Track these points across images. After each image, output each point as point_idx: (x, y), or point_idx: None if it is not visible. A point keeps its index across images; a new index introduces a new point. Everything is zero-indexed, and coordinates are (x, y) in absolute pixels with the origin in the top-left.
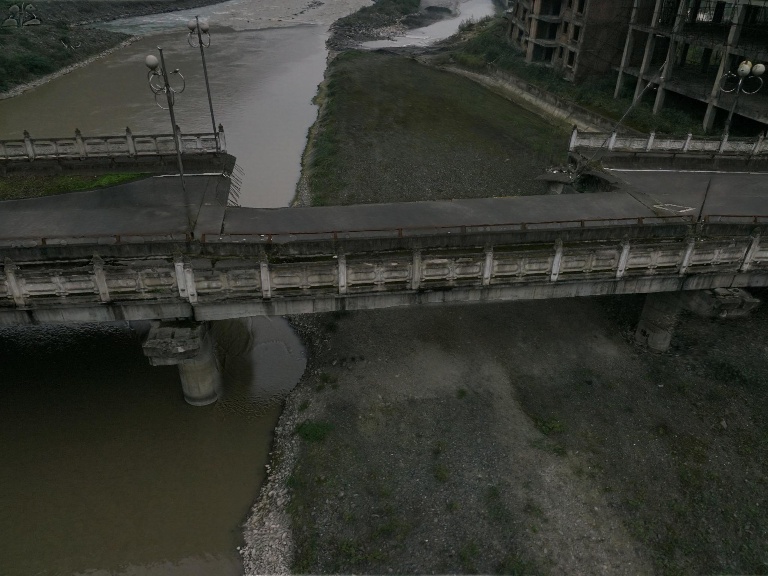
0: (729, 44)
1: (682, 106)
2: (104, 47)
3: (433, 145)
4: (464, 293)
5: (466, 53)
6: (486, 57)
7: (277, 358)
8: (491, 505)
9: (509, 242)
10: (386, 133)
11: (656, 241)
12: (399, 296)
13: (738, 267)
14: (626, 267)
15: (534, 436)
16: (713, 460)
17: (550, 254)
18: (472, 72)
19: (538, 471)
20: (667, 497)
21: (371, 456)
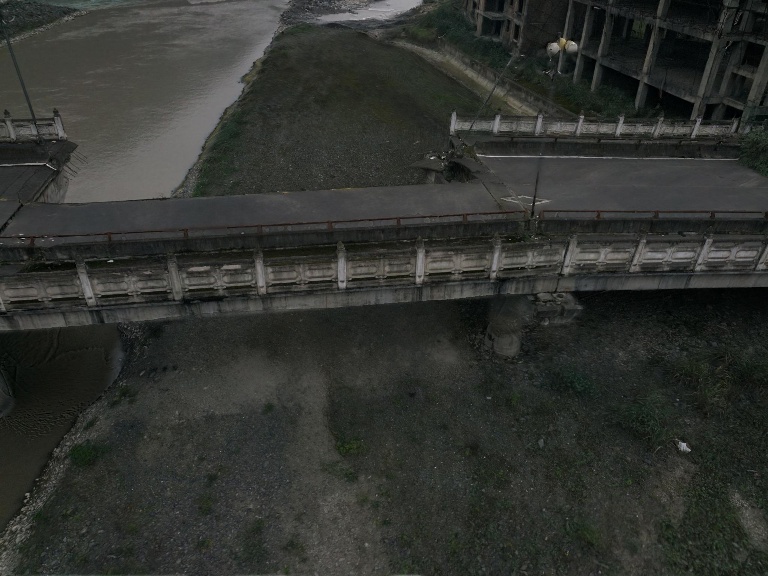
0: (658, 17)
1: (618, 83)
2: (41, 21)
3: (345, 126)
4: (242, 303)
5: (419, 27)
6: (437, 31)
7: (85, 367)
8: (249, 542)
9: (315, 242)
10: (300, 113)
11: (483, 240)
12: (165, 307)
13: (558, 270)
14: (426, 272)
15: (330, 458)
16: (515, 486)
17: (332, 259)
18: (421, 47)
19: (319, 500)
20: (448, 531)
21: (138, 484)
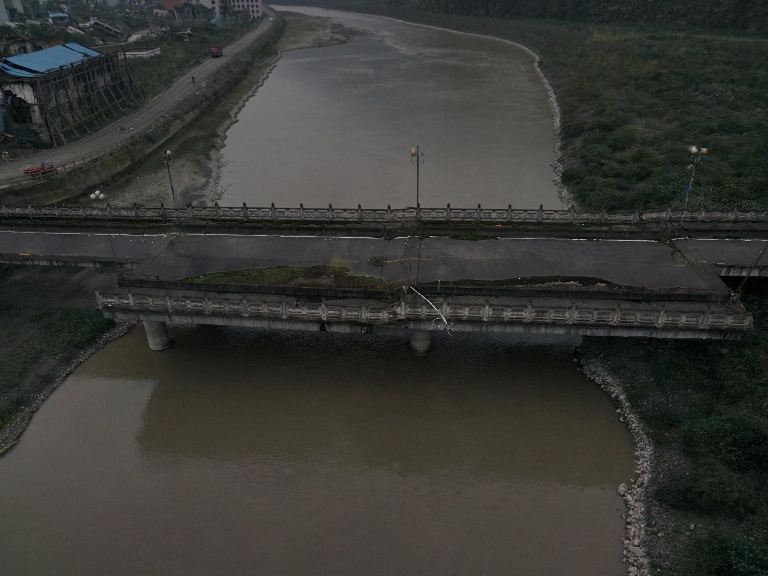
0: None
1: None
2: None
3: None
4: None
5: None
6: None
7: None
8: None
9: None
10: None
11: None
12: None
13: None
14: None
15: None
16: None
17: None
18: None
19: None
20: None
21: None
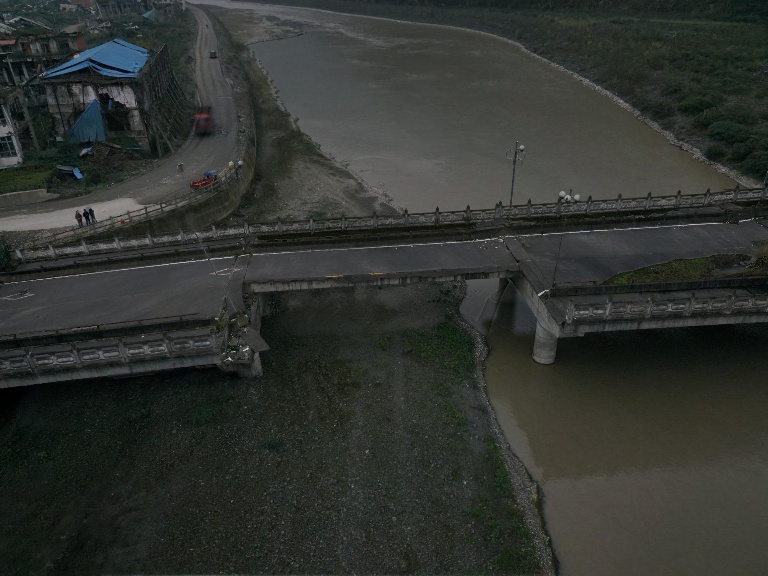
0: None
1: None
2: None
3: None
4: None
5: None
6: None
7: (476, 307)
8: None
9: None
10: None
11: None
12: None
13: None
14: None
15: None
16: None
17: None
18: None
19: None
20: None
21: None
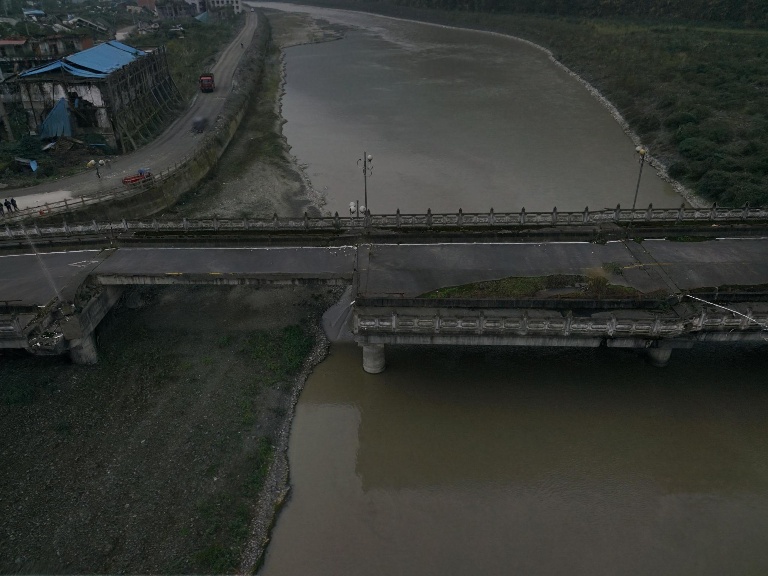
0: None
1: None
2: None
3: None
4: None
5: None
6: None
7: None
8: None
9: None
10: None
11: None
12: None
13: None
14: None
15: None
16: None
17: None
18: None
19: None
20: None
21: None
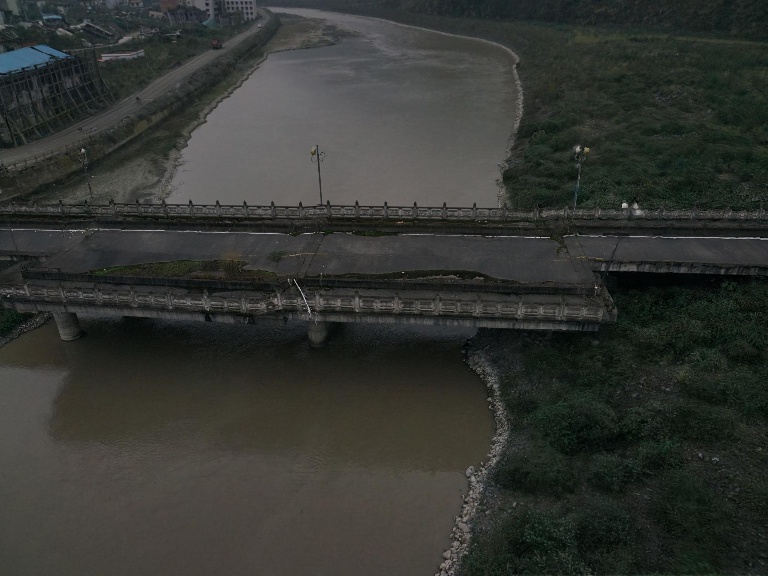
0: None
1: None
2: None
3: None
4: None
5: None
6: None
7: None
8: None
9: None
10: None
11: None
12: None
13: None
14: None
15: None
16: None
17: None
18: None
19: None
20: None
21: None
